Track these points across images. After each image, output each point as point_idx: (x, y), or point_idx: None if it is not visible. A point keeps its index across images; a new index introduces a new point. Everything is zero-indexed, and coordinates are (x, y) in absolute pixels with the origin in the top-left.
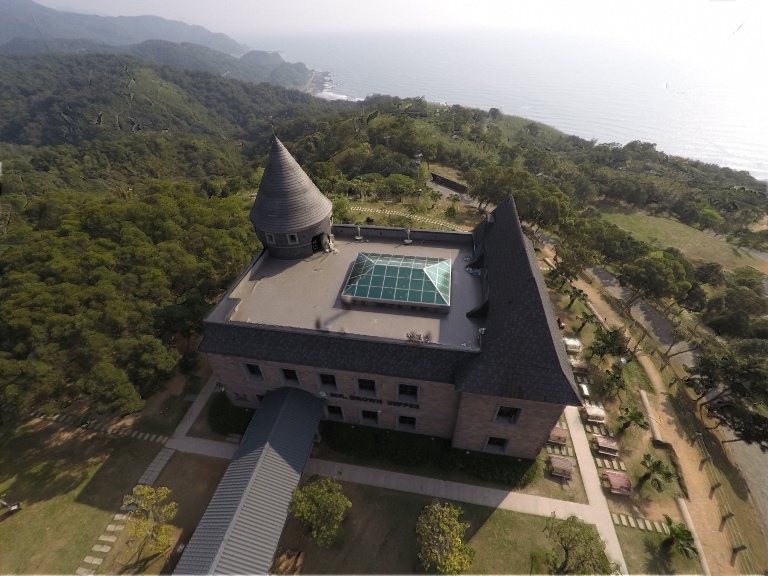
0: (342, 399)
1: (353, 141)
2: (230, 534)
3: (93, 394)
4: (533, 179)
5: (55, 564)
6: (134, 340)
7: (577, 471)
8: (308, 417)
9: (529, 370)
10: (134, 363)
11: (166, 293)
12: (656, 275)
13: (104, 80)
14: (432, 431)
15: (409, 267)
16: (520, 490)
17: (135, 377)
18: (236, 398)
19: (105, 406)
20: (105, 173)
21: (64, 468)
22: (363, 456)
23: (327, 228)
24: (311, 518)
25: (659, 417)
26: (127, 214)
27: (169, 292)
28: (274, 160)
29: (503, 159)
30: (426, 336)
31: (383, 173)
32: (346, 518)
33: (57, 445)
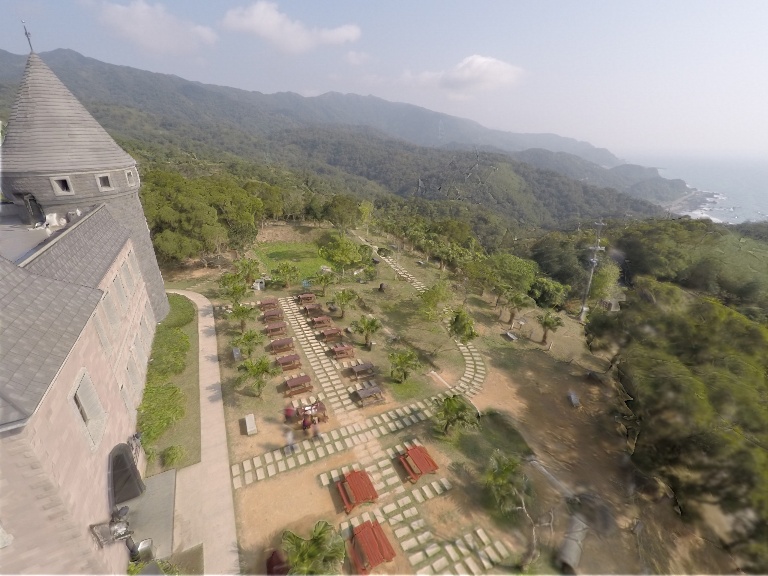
0: None
1: None
2: None
3: None
4: None
5: None
6: None
7: None
8: None
9: None
10: None
11: None
12: None
13: (460, 162)
14: None
15: None
16: None
17: None
18: None
19: None
20: None
21: None
22: None
23: (43, 192)
24: None
25: None
26: None
27: None
28: None
29: None
30: None
31: (544, 264)
32: None
33: None
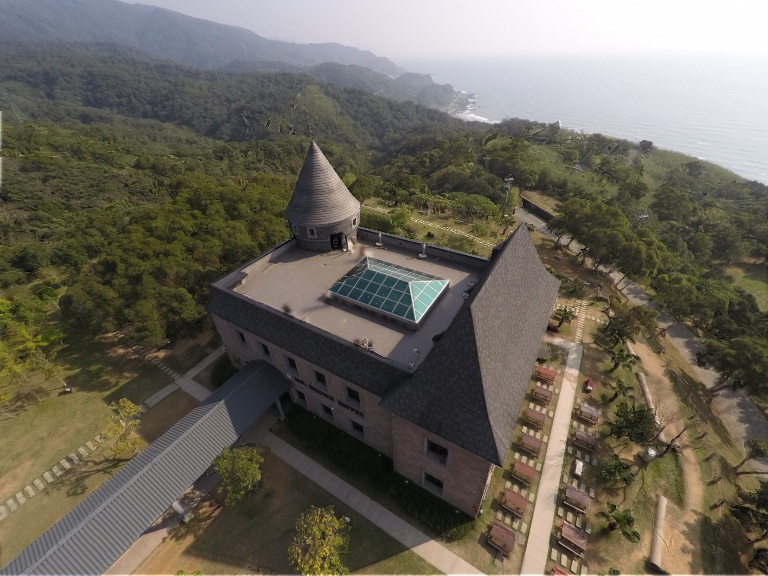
0: (303, 386)
1: (462, 160)
2: (158, 460)
3: (132, 322)
4: (626, 219)
5: (70, 438)
6: (174, 290)
7: (521, 552)
8: (269, 392)
9: (454, 407)
10: (168, 308)
11: (215, 260)
12: (751, 363)
13: (279, 93)
14: (380, 447)
15: (396, 277)
16: (444, 542)
17: (167, 319)
18: (234, 360)
19: (136, 334)
20: (259, 167)
21: (108, 374)
22: (311, 446)
23: (348, 229)
24: (224, 475)
25: (671, 537)
26: (220, 195)
27: (218, 260)
28: (309, 161)
29: (620, 196)
30: (371, 344)
31: (471, 193)
32: (269, 494)
33: (112, 356)
